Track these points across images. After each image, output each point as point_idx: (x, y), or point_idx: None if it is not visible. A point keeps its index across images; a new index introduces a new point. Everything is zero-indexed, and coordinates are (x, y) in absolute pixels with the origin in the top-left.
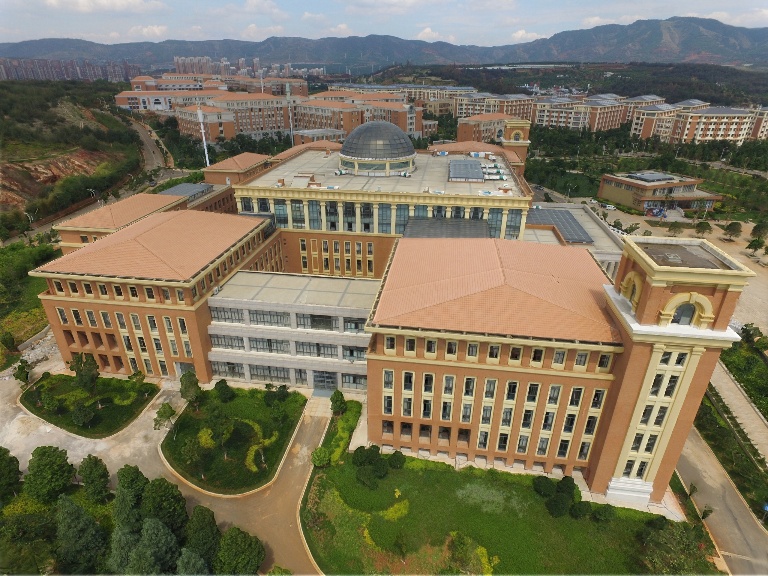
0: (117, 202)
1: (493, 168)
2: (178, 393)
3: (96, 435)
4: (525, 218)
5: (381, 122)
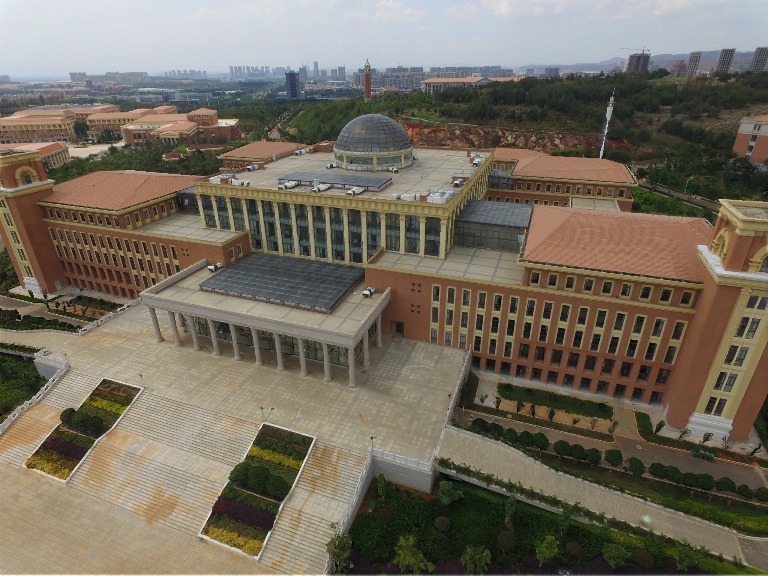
0: None
1: None
2: None
3: None
4: (199, 202)
5: (366, 115)
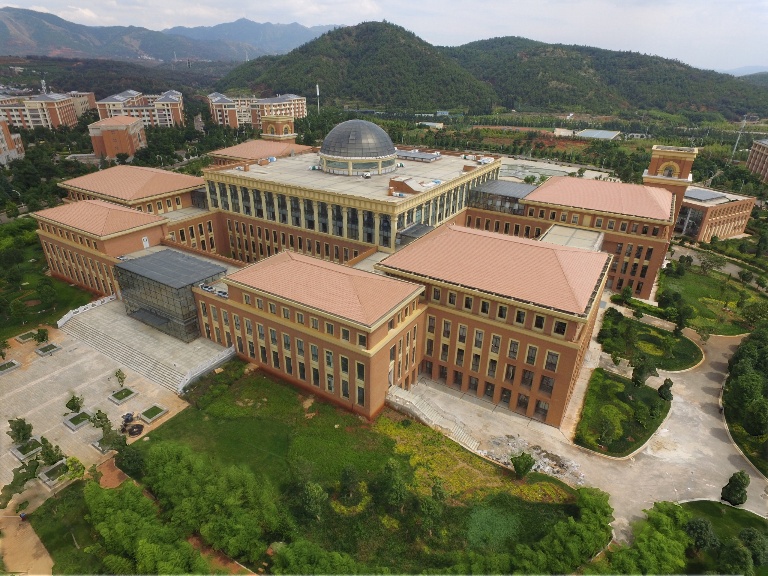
0: (336, 270)
1: None
2: (603, 360)
3: (666, 401)
4: None
5: None
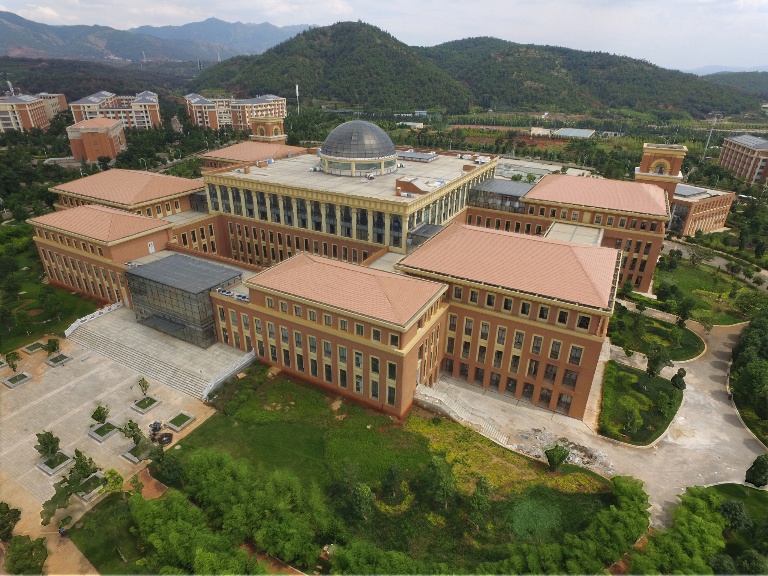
0: (361, 272)
1: None
2: (614, 353)
3: (679, 390)
4: None
5: None
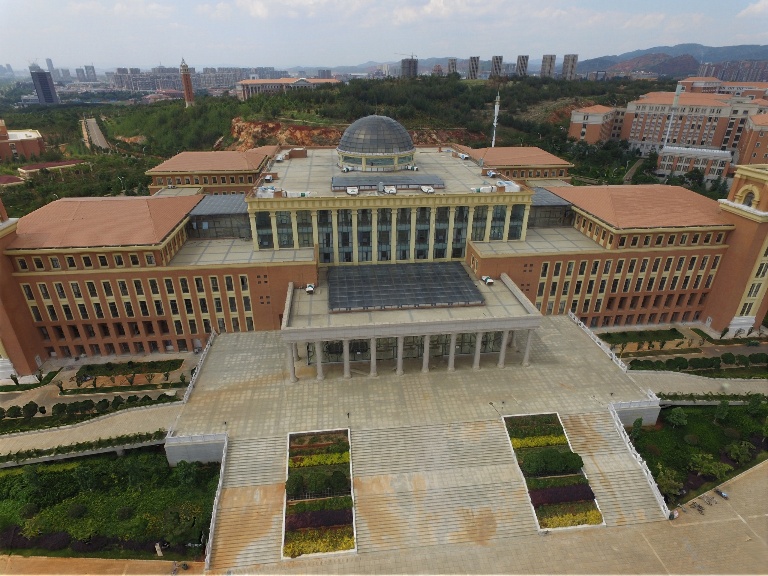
0: None
1: (424, 193)
2: None
3: None
4: (251, 221)
5: (371, 116)
